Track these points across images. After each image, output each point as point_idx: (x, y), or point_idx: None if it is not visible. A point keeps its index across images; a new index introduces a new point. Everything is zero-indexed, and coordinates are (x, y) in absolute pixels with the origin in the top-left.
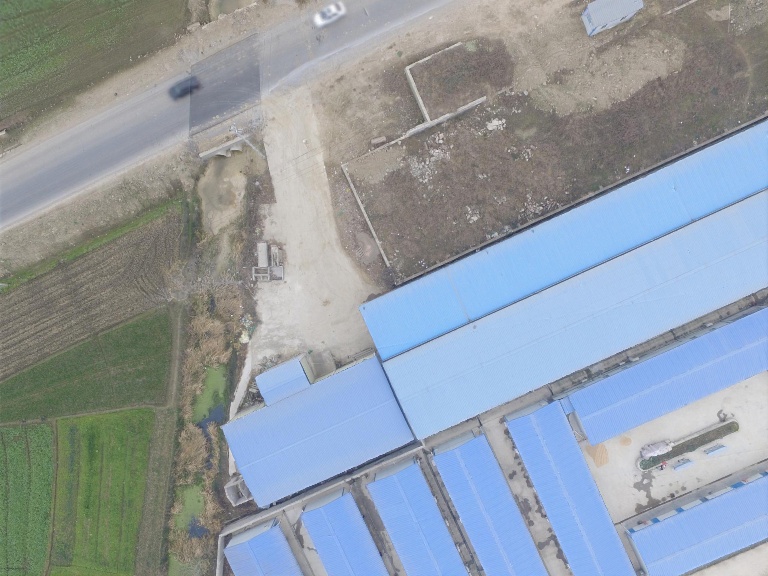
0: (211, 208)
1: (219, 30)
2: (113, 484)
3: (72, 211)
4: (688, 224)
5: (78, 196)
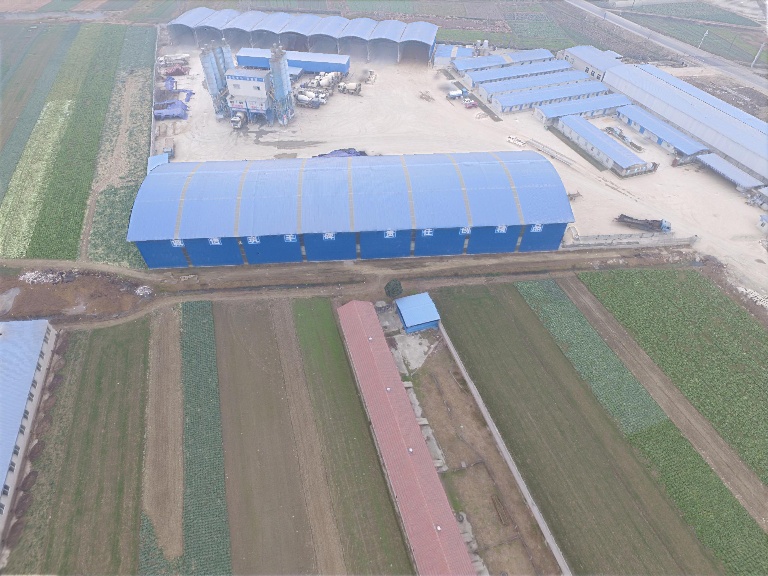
0: (661, 62)
1: (731, 61)
2: None
3: (647, 40)
4: None
5: (652, 41)
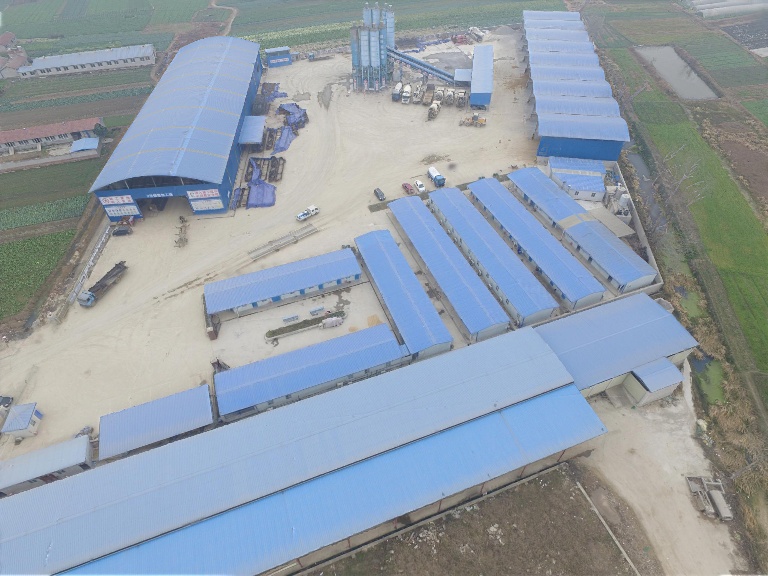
0: None
1: None
2: (766, 320)
3: None
4: (289, 488)
5: None
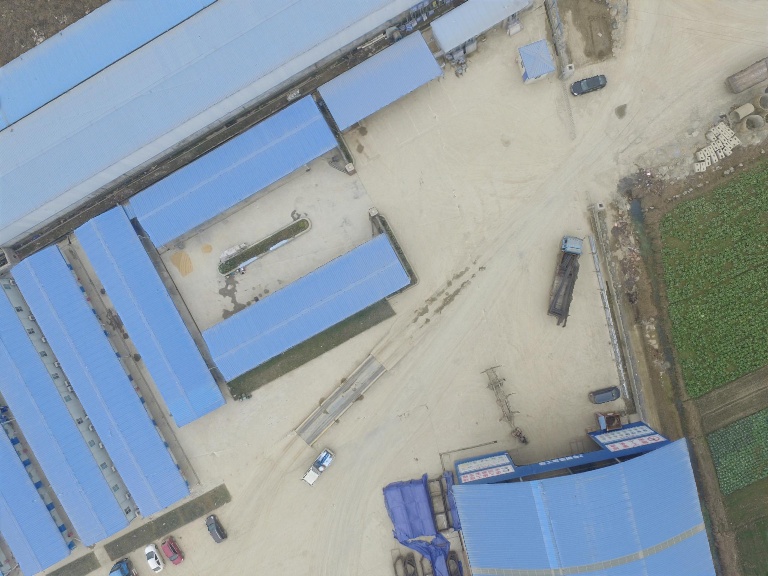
0: None
1: None
2: None
3: None
4: (199, 11)
5: None
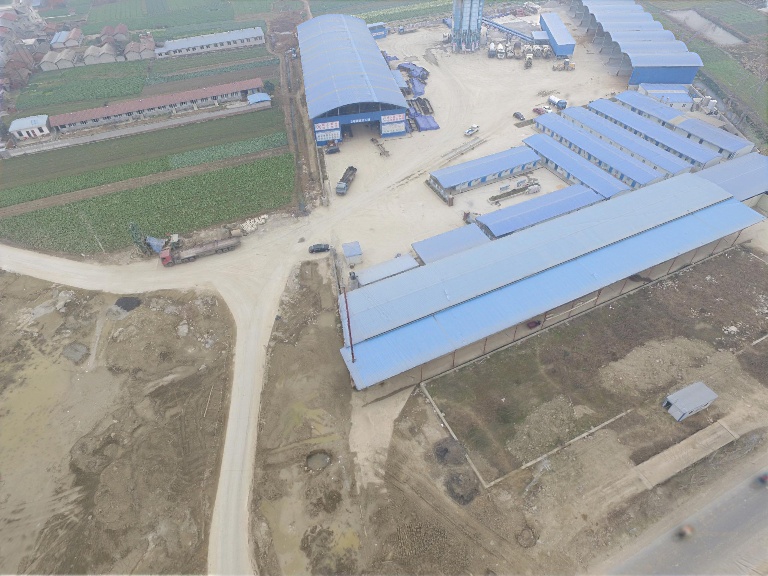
0: None
1: None
2: None
3: None
4: (579, 257)
5: None
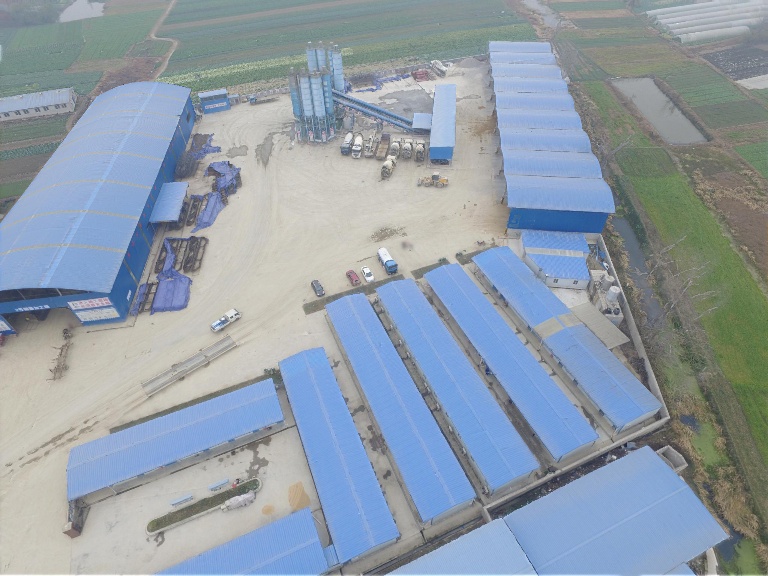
0: None
1: None
2: None
3: None
4: None
5: None
